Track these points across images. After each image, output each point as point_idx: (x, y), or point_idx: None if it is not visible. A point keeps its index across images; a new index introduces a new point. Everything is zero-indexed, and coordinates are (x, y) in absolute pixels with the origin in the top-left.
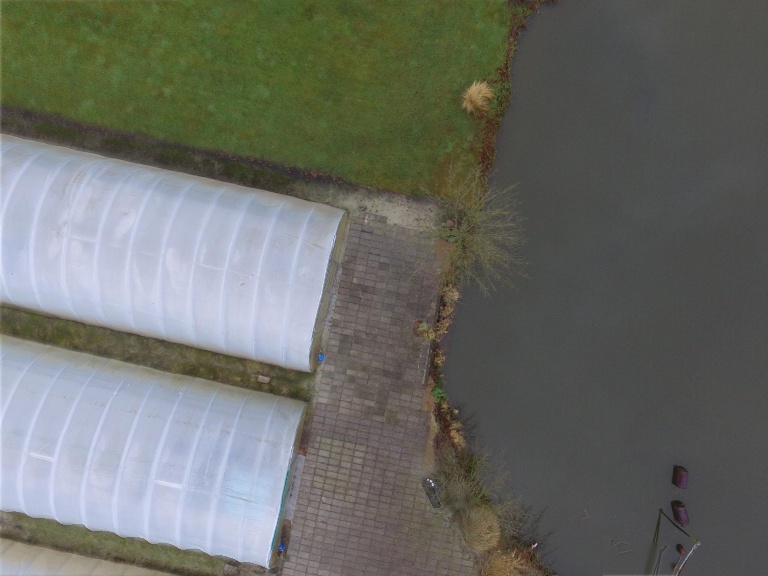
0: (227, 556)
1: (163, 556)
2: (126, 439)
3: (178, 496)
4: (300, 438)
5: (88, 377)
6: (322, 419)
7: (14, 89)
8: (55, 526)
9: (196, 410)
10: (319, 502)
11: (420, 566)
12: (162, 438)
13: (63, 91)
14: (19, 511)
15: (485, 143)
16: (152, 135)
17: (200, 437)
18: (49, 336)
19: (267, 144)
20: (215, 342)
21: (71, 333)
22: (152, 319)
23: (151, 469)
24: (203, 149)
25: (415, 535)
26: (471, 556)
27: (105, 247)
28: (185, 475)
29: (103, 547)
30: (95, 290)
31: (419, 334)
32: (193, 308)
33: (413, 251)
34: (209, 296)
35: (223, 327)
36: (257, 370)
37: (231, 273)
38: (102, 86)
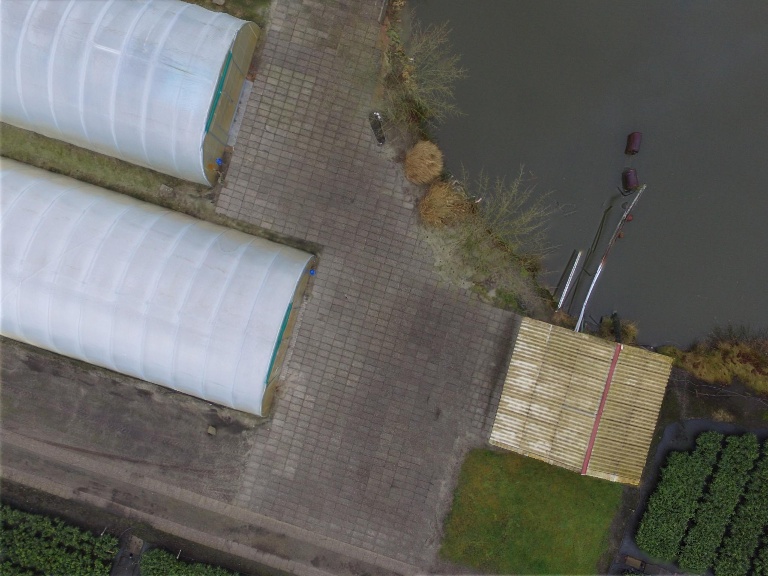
0: (162, 160)
1: (99, 170)
2: (69, 1)
3: (115, 60)
4: (249, 62)
5: None
6: (274, 47)
7: None
8: None
9: None
10: (263, 130)
11: (359, 204)
12: (106, 5)
13: None
14: None
15: None
16: None
17: (145, 11)
18: None
19: None
20: None
21: None
22: None
23: (91, 30)
24: None
25: (357, 172)
26: (412, 199)
27: None
28: (125, 39)
29: (39, 155)
30: None
31: None
32: None
33: None
34: None
35: None
36: None
37: None
38: None
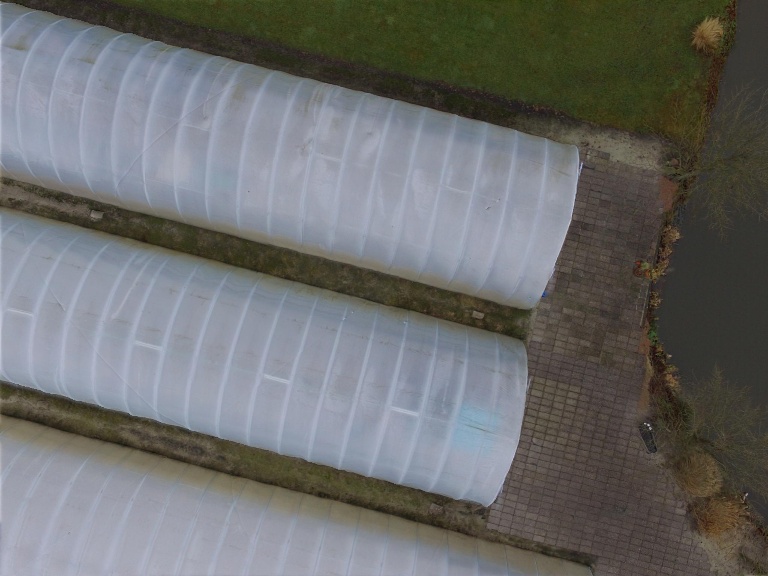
0: (443, 492)
1: (368, 492)
2: (362, 363)
3: (415, 423)
4: None
5: (313, 302)
6: (536, 358)
7: (234, 12)
8: (259, 457)
9: (425, 339)
10: (530, 443)
11: (631, 513)
12: (398, 364)
13: (284, 15)
14: (230, 439)
15: (711, 82)
16: (372, 63)
17: (435, 365)
18: (261, 263)
19: (489, 75)
20: (444, 271)
21: (283, 261)
22: (386, 244)
23: (389, 394)
24: (423, 78)
25: (627, 481)
26: (684, 504)
27: (350, 166)
28: (423, 402)
29: (307, 481)
30: (334, 210)
31: (640, 274)
32: (434, 232)
33: (635, 189)
34: (453, 220)
35: (461, 253)
36: (471, 305)
37: (478, 196)
38: (324, 11)
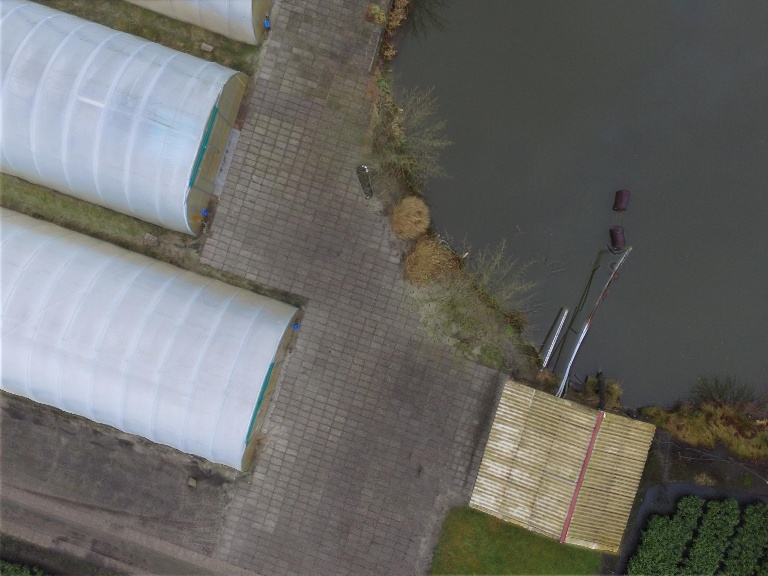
0: (146, 211)
1: (83, 217)
2: (53, 52)
3: (99, 114)
4: (237, 111)
5: None
6: (262, 95)
7: None
8: None
9: (130, 45)
10: (249, 180)
11: (345, 257)
12: (90, 57)
13: None
14: None
15: None
16: None
17: (130, 63)
18: None
19: None
20: None
21: None
22: None
23: (74, 82)
24: None
25: (344, 225)
26: (399, 253)
27: None
28: (108, 92)
29: (23, 201)
30: None
31: (370, 17)
32: None
33: None
34: None
35: None
36: (201, 38)
37: None
38: None
